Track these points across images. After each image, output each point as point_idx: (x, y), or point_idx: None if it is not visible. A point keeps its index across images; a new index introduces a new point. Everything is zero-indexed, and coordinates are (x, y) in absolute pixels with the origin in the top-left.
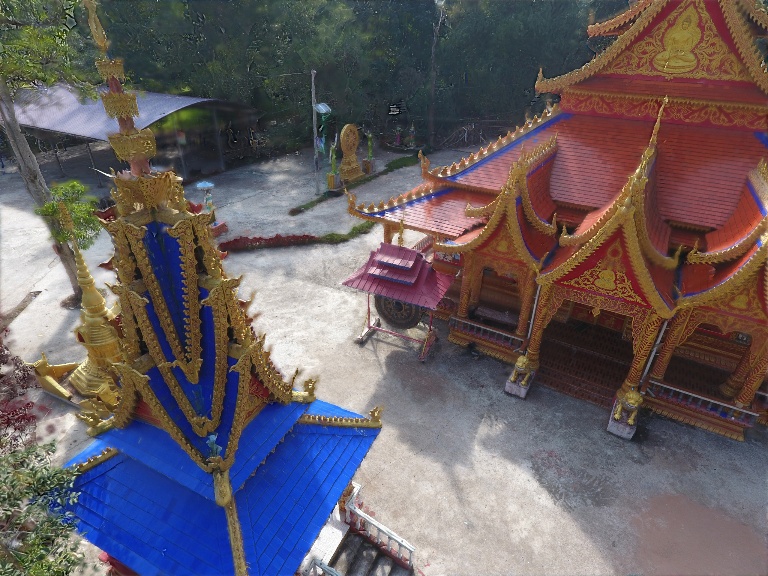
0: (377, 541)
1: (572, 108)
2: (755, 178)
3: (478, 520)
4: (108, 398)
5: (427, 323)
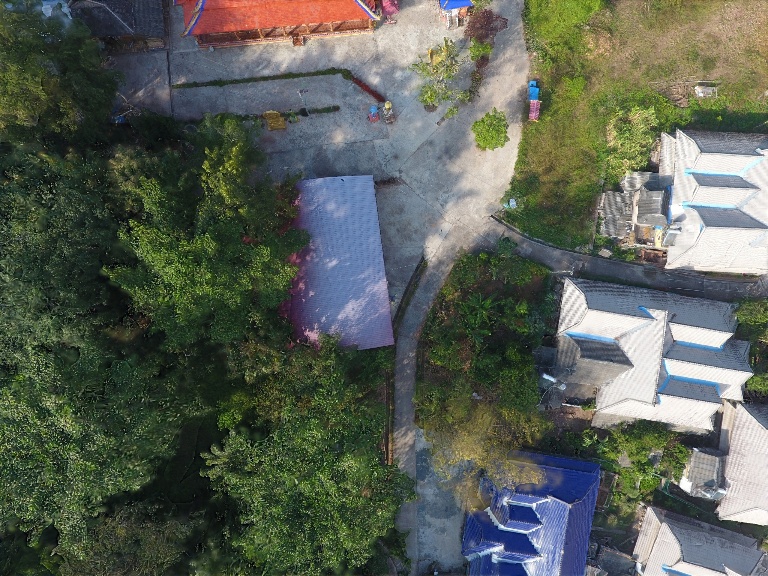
0: None
1: None
2: None
3: None
4: None
5: (376, 12)
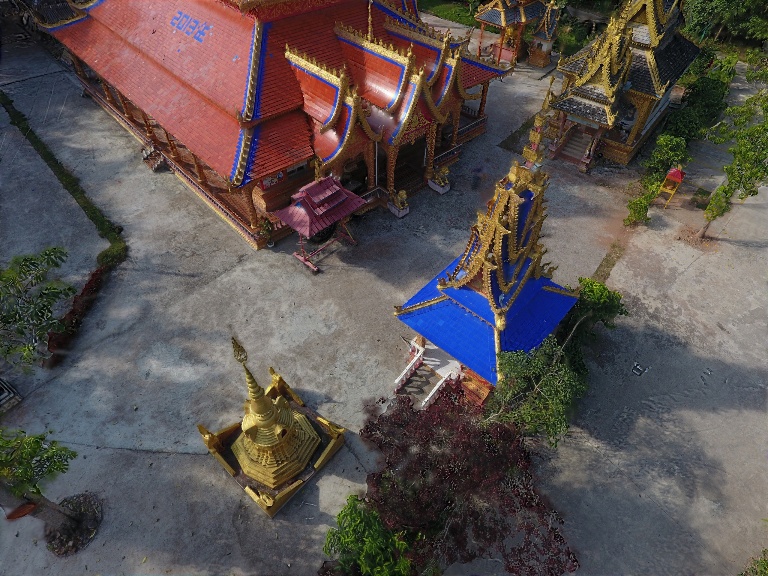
0: None
1: (268, 17)
2: (397, 29)
3: None
4: None
5: None
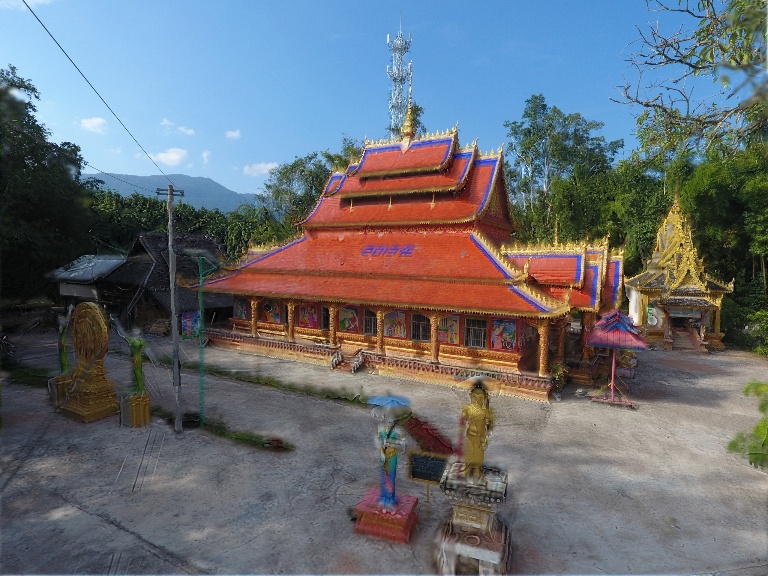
0: None
1: None
2: None
3: None
4: None
5: (575, 390)
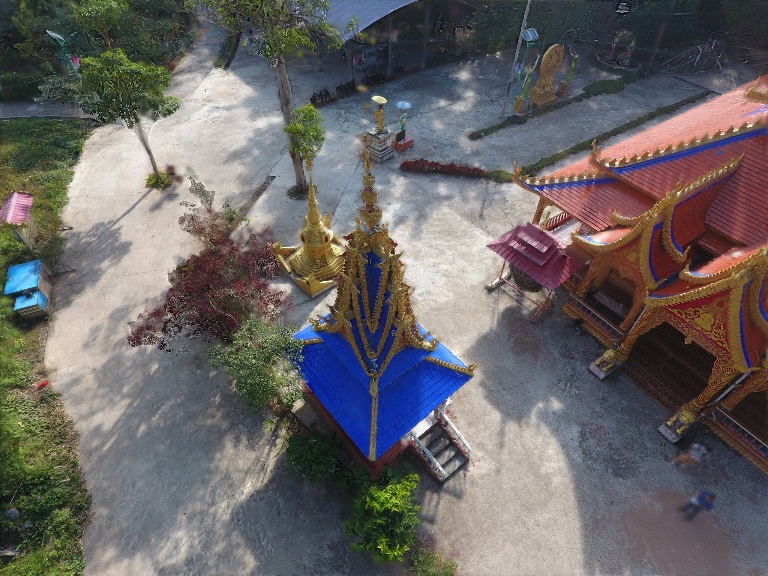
0: (452, 436)
1: None
2: None
3: (523, 449)
4: (313, 284)
5: None
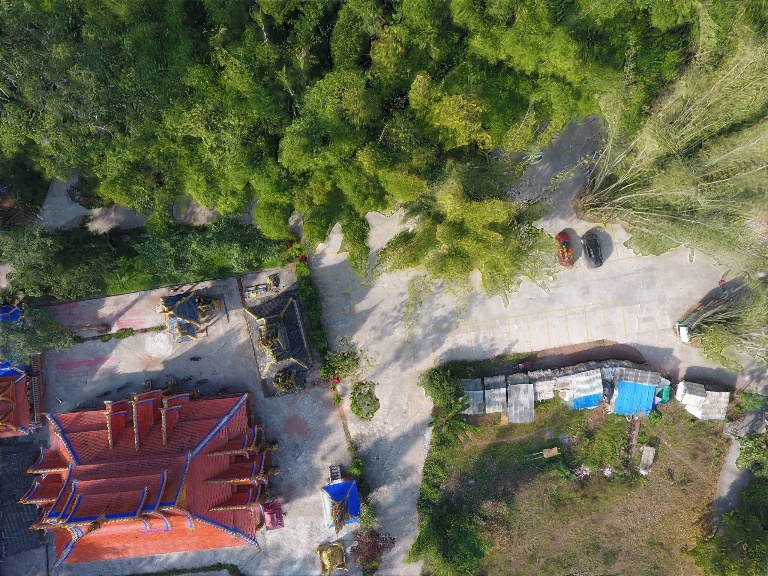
0: None
1: None
2: None
3: (315, 462)
4: None
5: None
